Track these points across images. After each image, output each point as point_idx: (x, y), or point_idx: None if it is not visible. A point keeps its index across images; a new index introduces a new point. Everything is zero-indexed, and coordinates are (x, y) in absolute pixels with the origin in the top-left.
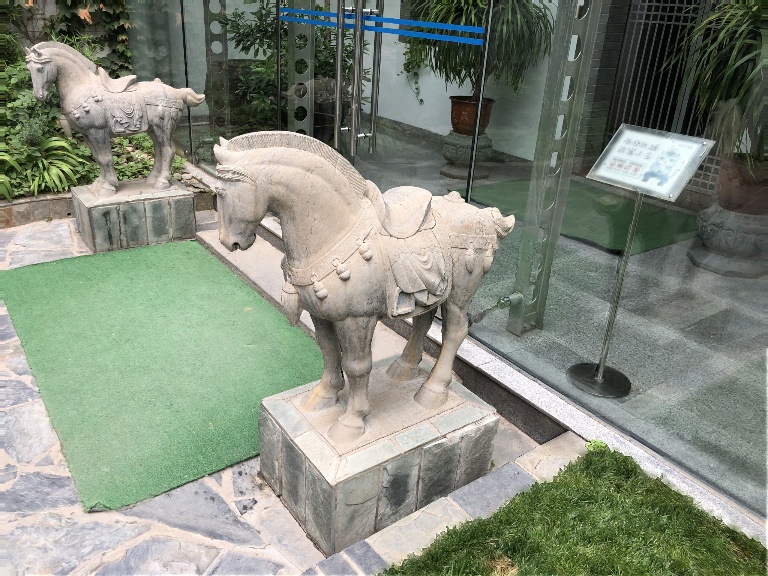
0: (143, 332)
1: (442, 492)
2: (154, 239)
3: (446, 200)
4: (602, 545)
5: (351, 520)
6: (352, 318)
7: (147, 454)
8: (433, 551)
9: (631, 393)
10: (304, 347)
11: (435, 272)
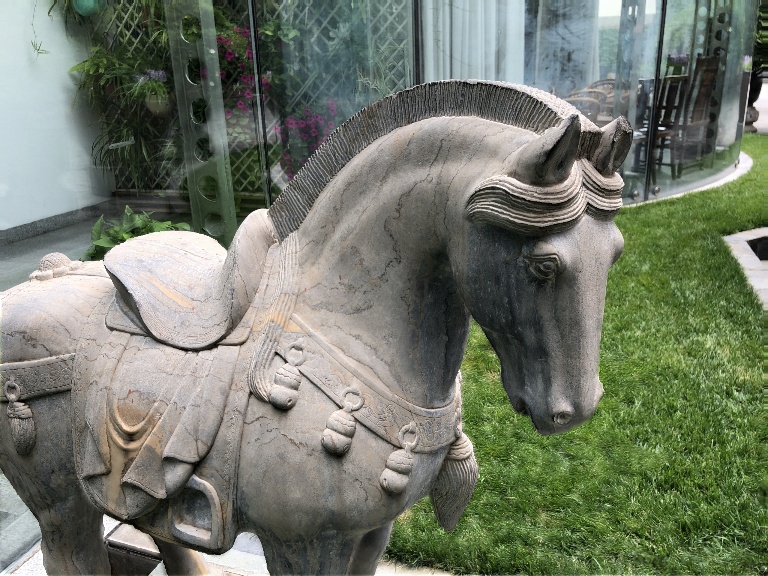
0: None
1: None
2: None
3: (79, 269)
4: None
5: None
6: None
7: None
8: (438, 545)
9: None
10: None
11: None
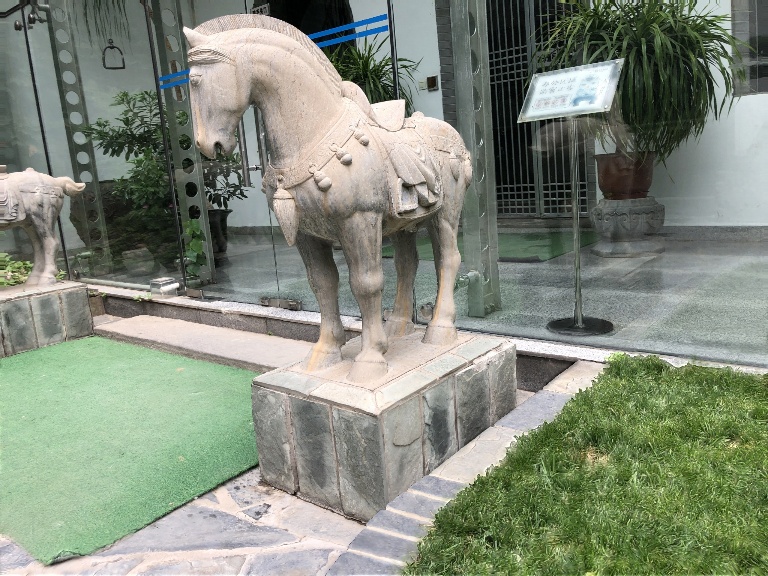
0: (61, 408)
1: None
2: (45, 341)
3: None
4: (676, 416)
5: (401, 469)
6: (360, 213)
7: (110, 498)
8: (514, 454)
9: (615, 329)
10: None
11: (429, 167)
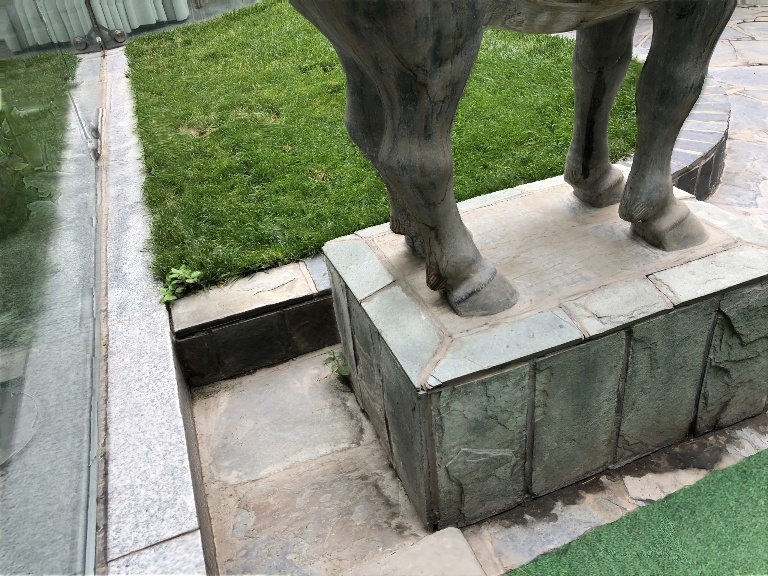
0: None
1: None
2: None
3: None
4: (300, 201)
5: None
6: None
7: None
8: None
9: None
10: None
11: None
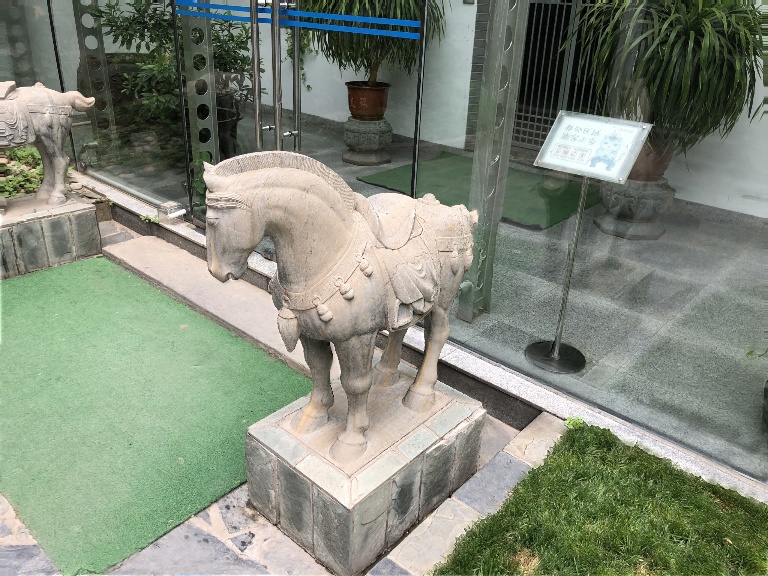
0: (74, 367)
1: (440, 492)
2: (56, 260)
3: (423, 203)
4: (607, 519)
5: (365, 538)
6: (356, 337)
7: (119, 504)
8: (460, 556)
9: (586, 366)
10: (256, 360)
11: (429, 279)
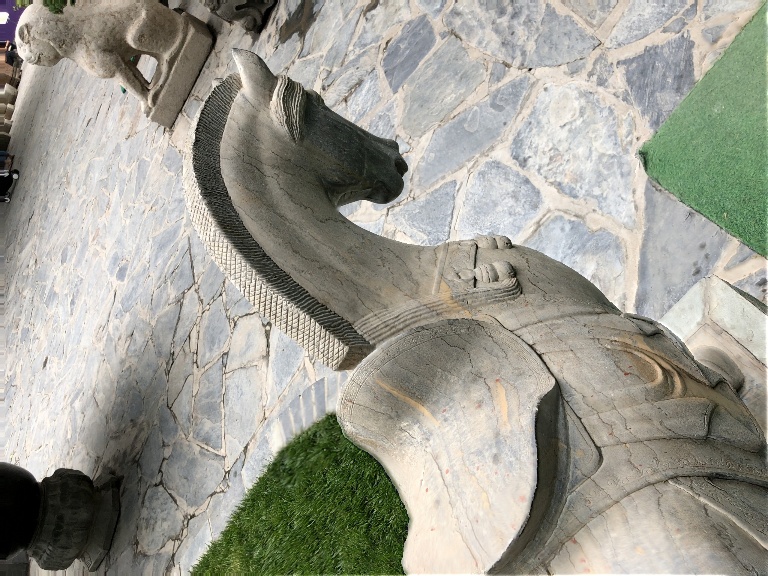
0: None
1: None
2: None
3: None
4: None
5: None
6: None
7: (759, 133)
8: None
9: None
10: None
11: None
